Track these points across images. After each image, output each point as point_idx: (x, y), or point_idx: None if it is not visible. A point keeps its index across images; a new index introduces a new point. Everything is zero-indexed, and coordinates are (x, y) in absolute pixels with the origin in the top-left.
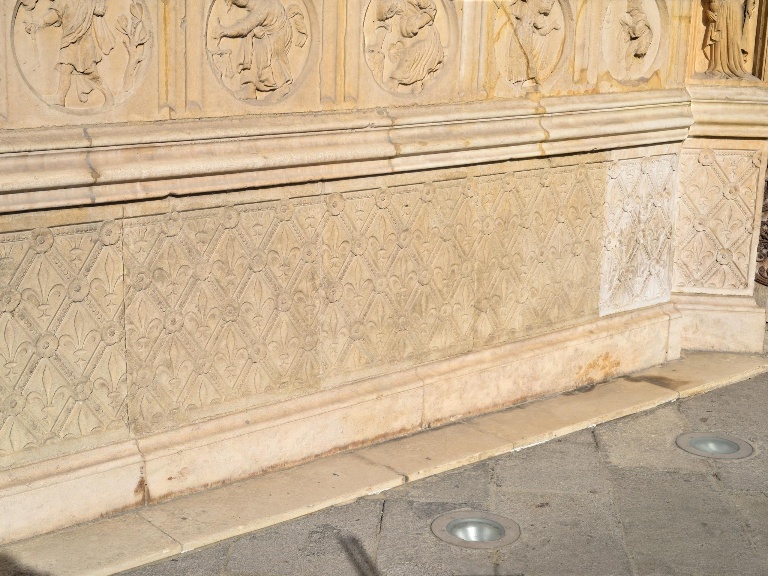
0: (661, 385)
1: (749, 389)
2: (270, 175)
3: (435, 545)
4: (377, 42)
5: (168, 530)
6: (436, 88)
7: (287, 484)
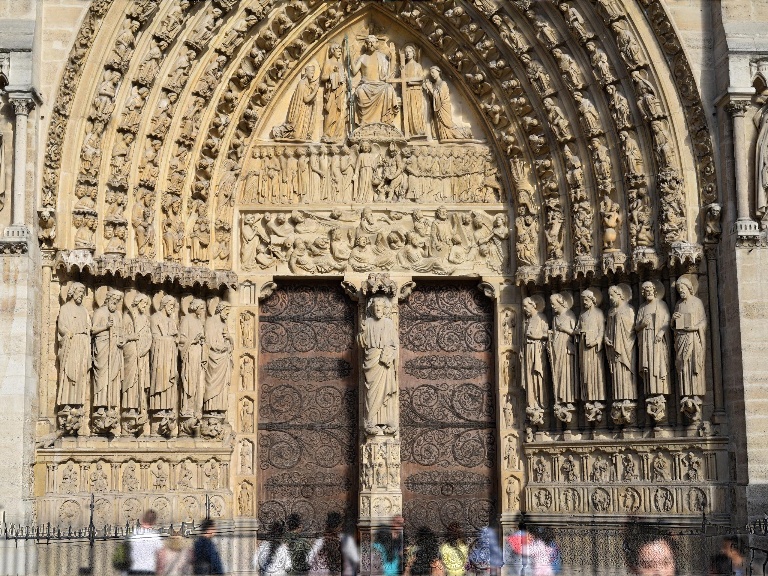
0: None
1: None
2: None
3: None
4: (155, 511)
5: None
6: (168, 520)
7: None
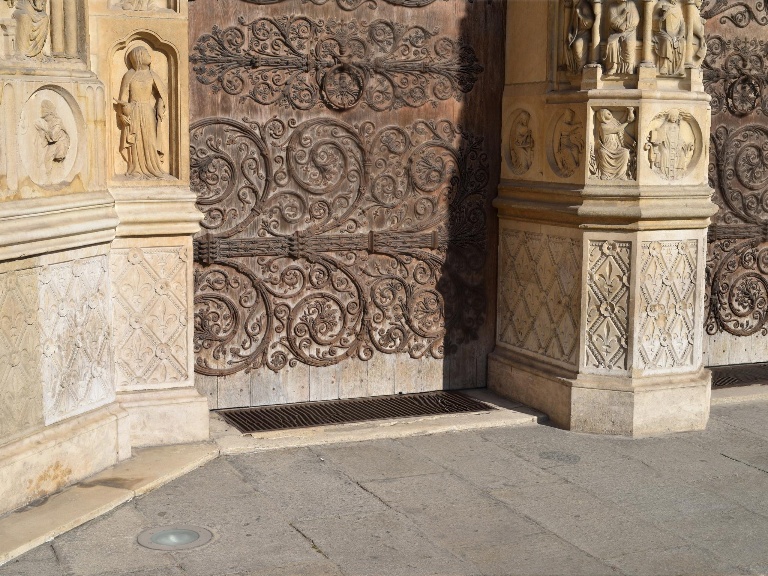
0: (116, 486)
1: (201, 477)
2: None
3: None
4: None
5: None
6: None
7: None
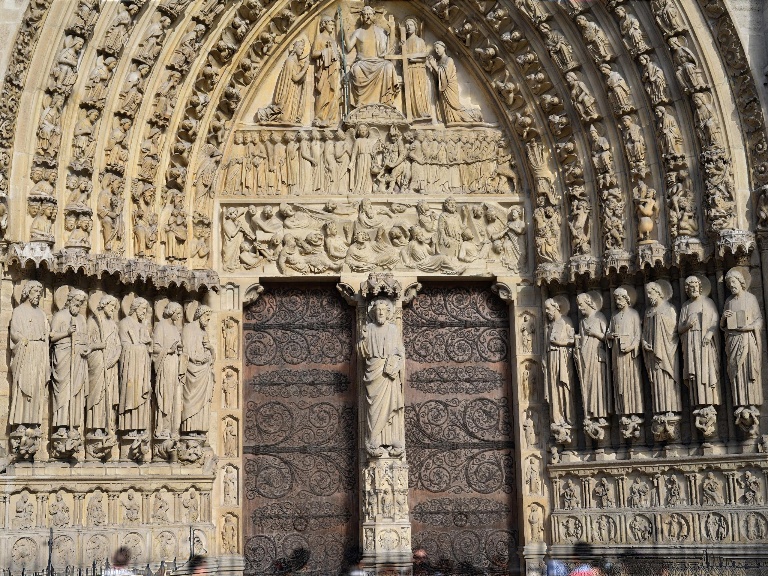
0: None
1: None
2: None
3: None
4: (125, 549)
5: None
6: (140, 559)
7: None
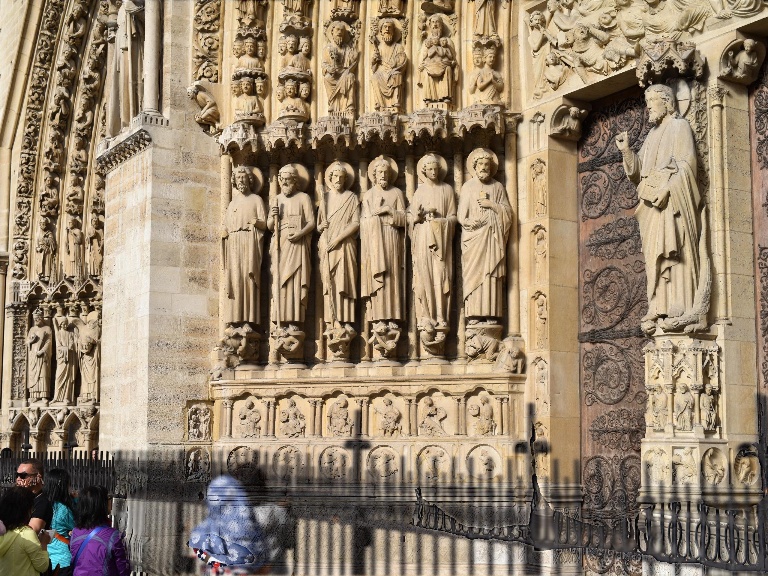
0: None
1: None
2: None
3: None
4: None
5: None
6: (394, 478)
7: None
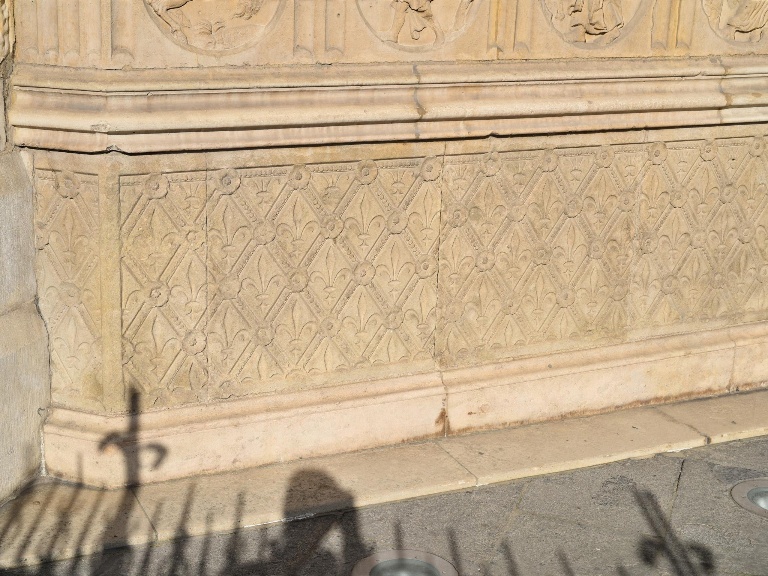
0: None
1: None
2: (593, 120)
3: (734, 511)
4: None
5: (465, 463)
6: None
7: (585, 432)
